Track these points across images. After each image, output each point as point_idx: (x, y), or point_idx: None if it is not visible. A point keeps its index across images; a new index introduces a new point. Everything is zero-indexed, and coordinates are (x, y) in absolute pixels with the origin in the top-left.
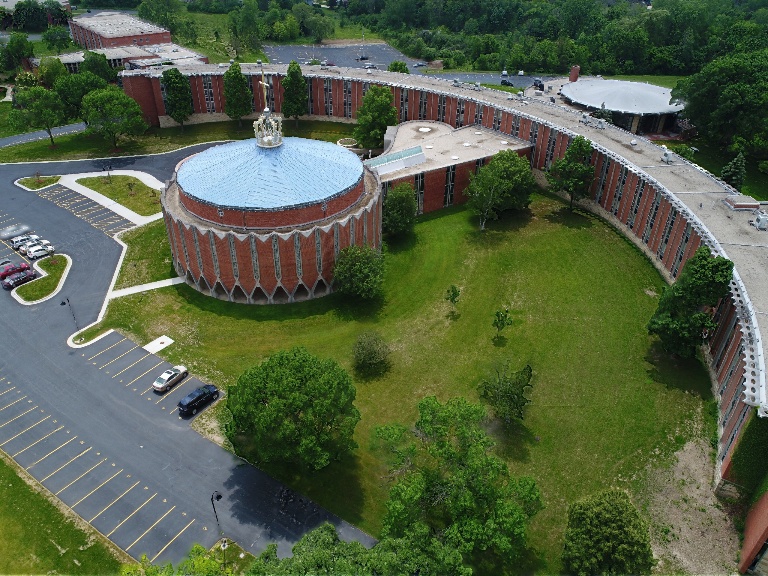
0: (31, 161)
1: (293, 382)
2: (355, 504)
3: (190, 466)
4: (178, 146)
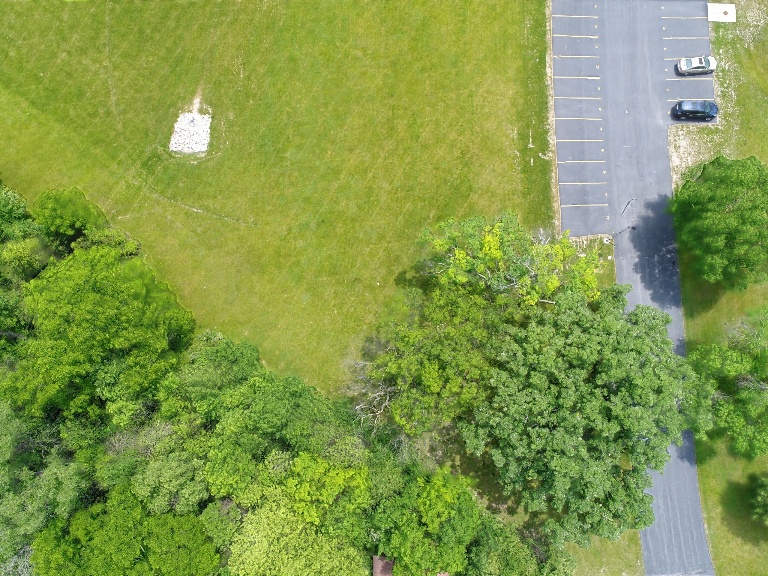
0: None
1: (763, 217)
2: (700, 302)
3: (640, 162)
4: None
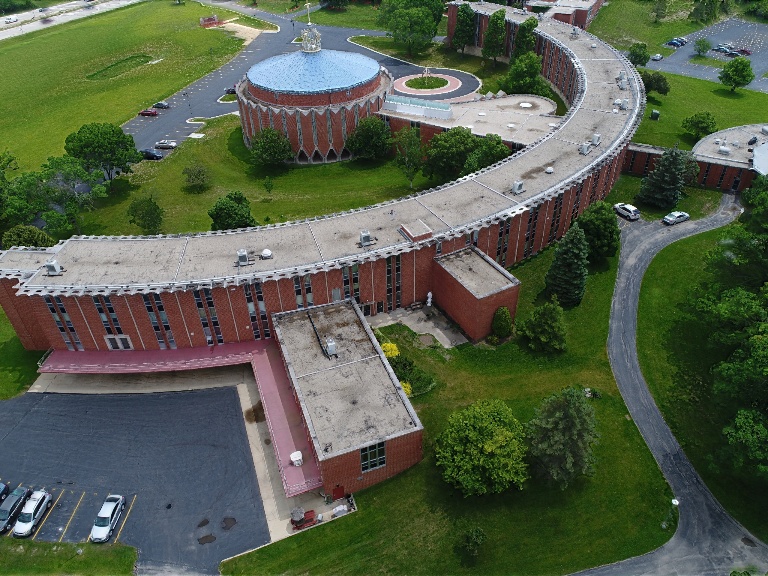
0: (368, 47)
1: (85, 130)
2: (87, 210)
3: None
4: (439, 66)
